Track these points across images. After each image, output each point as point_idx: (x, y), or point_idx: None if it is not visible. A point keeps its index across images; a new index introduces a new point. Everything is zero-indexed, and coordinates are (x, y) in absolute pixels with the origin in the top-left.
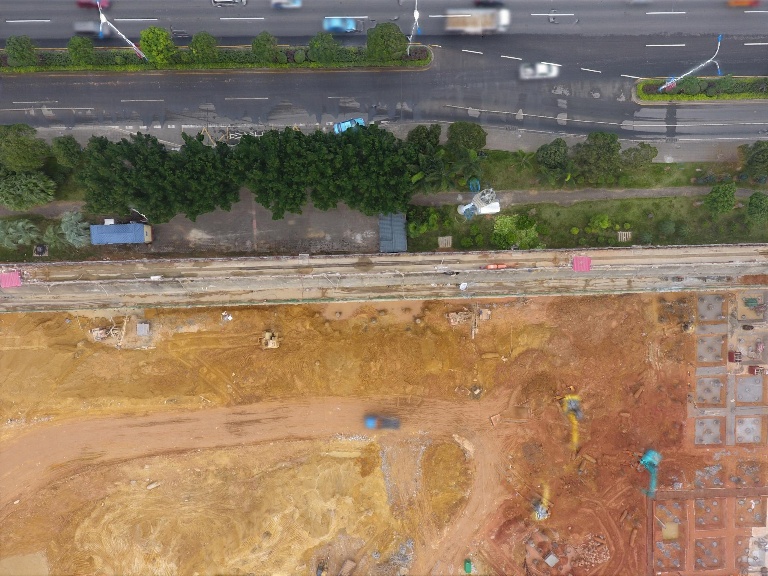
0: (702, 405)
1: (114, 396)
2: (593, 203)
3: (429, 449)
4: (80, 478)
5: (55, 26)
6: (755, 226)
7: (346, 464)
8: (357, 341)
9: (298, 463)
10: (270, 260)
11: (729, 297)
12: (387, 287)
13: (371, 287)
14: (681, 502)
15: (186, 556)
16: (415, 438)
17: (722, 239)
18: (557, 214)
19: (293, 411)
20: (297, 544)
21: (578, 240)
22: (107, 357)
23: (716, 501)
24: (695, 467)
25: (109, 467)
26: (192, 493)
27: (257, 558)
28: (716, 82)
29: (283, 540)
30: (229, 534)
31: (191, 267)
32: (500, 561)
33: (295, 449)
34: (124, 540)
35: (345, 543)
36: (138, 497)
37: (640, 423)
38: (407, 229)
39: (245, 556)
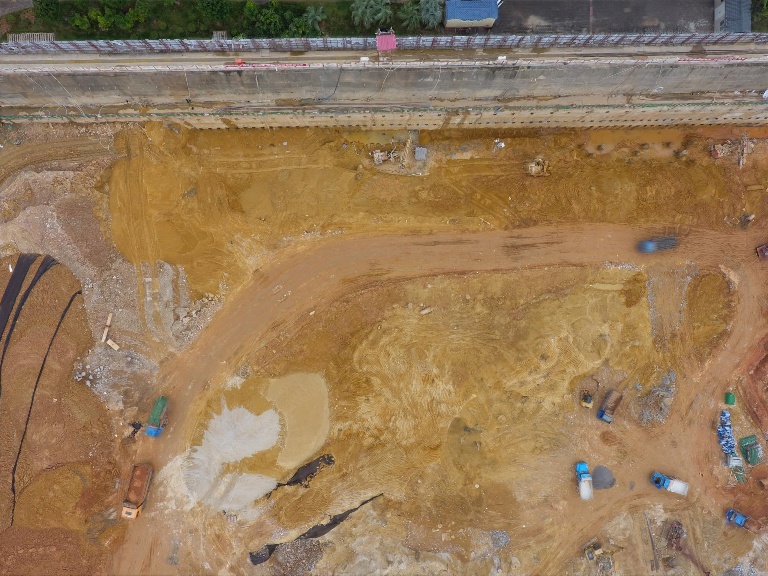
0: None
1: (401, 213)
2: None
3: (695, 280)
4: (369, 293)
5: None
6: None
7: (611, 295)
8: (626, 170)
9: (562, 294)
10: (607, 47)
11: None
12: (691, 94)
13: (675, 94)
14: None
15: (458, 381)
16: (682, 268)
17: None
18: None
19: (567, 236)
20: (572, 368)
21: None
22: (385, 180)
23: None
24: None
25: (395, 284)
26: (461, 321)
27: (534, 380)
28: None
29: (560, 363)
30: (497, 362)
31: (529, 53)
32: (752, 400)
33: (563, 278)
34: (403, 361)
35: (607, 375)
36: (411, 322)
37: None
38: (753, 9)
39: (523, 378)
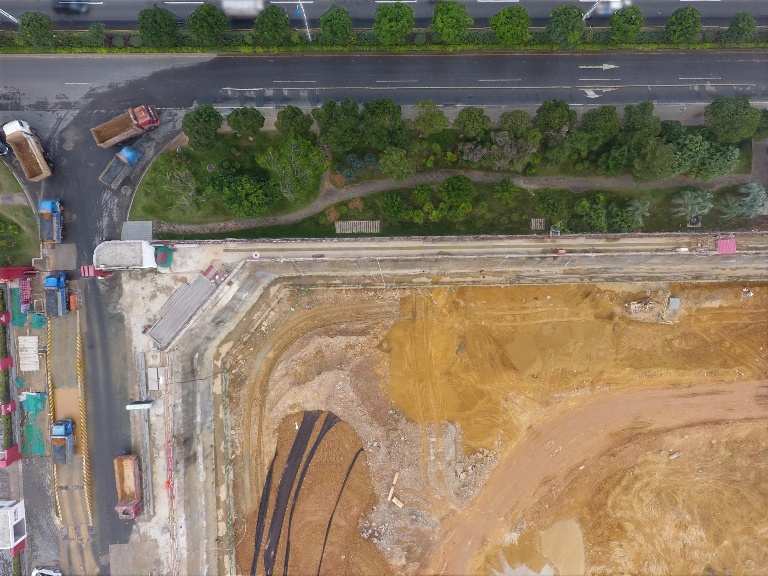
0: None
1: (663, 367)
2: None
3: None
4: (632, 446)
5: (724, 5)
6: None
7: None
8: None
9: None
10: None
11: None
12: None
13: None
14: None
15: (706, 525)
16: None
17: None
18: None
19: None
20: None
21: None
22: (640, 330)
23: None
24: None
25: (656, 436)
26: (705, 464)
27: None
28: None
29: None
30: (741, 505)
31: None
32: None
33: None
34: (657, 508)
35: None
36: (660, 467)
37: None
38: None
39: None
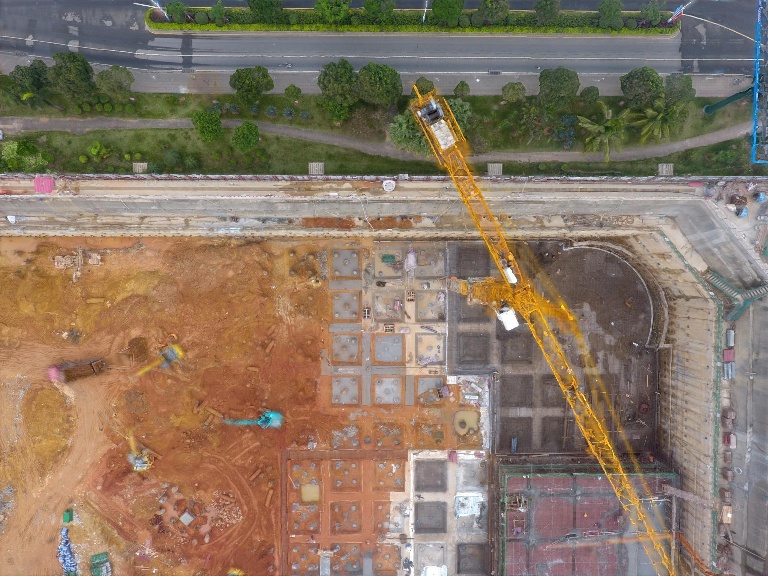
0: (338, 363)
1: None
2: (106, 132)
3: (28, 393)
4: None
5: None
6: (277, 161)
7: None
8: None
9: None
10: None
11: (362, 252)
12: None
13: None
14: (318, 463)
15: None
16: (13, 382)
17: (241, 173)
18: (68, 142)
19: None
20: None
21: (87, 169)
22: None
23: (355, 463)
24: (329, 426)
25: None
26: None
27: None
28: (226, 12)
29: None
30: None
31: None
32: (115, 514)
33: None
34: None
35: None
36: None
37: (271, 379)
38: None
39: None
